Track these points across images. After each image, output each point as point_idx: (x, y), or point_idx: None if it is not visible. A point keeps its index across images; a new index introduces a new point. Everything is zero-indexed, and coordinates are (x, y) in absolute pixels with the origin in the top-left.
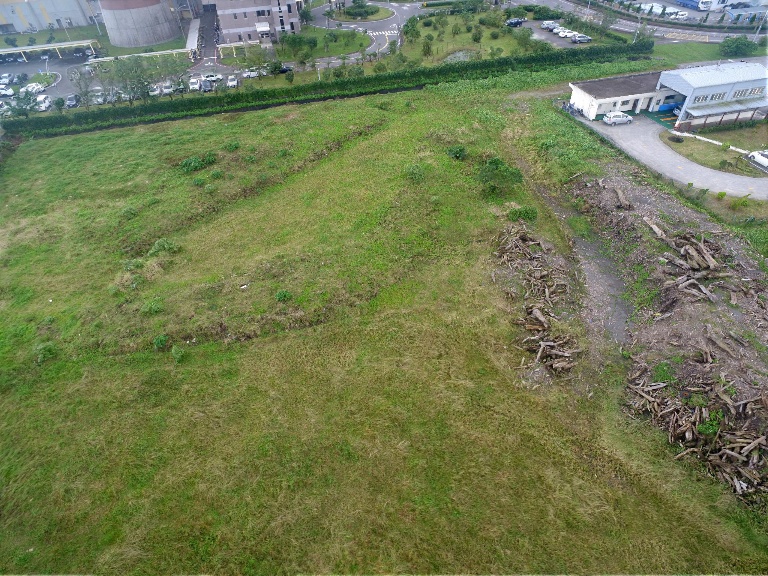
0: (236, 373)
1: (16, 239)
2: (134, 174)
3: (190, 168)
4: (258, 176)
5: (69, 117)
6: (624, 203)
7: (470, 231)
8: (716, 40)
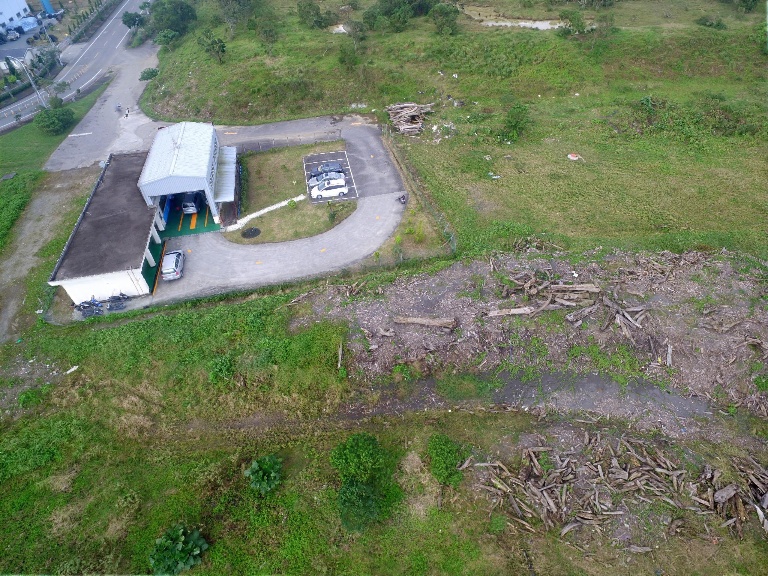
0: None
1: None
2: None
3: None
4: None
5: None
6: (447, 323)
7: (496, 571)
8: (4, 125)
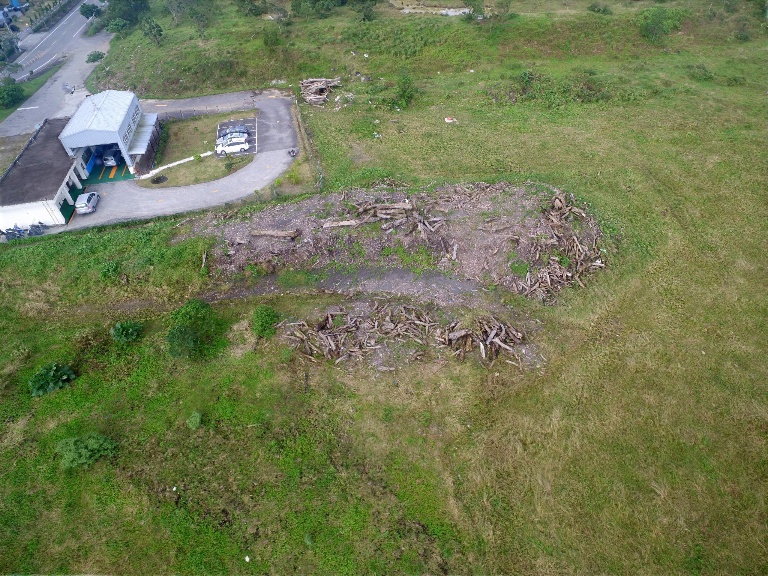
0: None
1: None
2: None
3: None
4: None
5: None
6: (290, 233)
7: (281, 385)
8: None
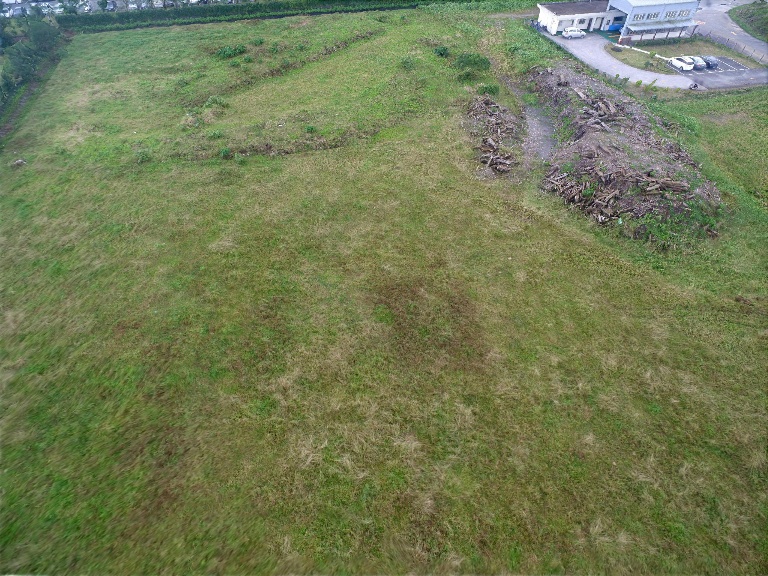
0: (281, 170)
1: (95, 97)
2: (180, 58)
3: (225, 55)
4: (282, 62)
5: (113, 16)
6: (563, 81)
7: (448, 100)
8: None
